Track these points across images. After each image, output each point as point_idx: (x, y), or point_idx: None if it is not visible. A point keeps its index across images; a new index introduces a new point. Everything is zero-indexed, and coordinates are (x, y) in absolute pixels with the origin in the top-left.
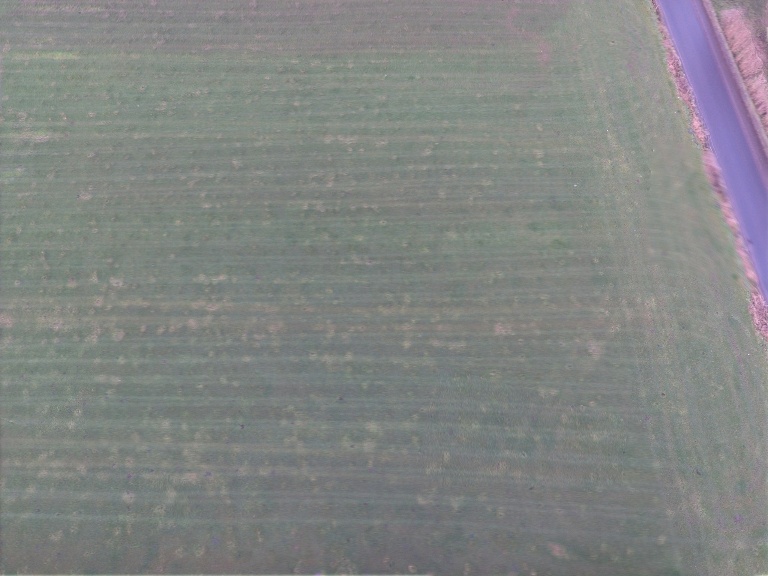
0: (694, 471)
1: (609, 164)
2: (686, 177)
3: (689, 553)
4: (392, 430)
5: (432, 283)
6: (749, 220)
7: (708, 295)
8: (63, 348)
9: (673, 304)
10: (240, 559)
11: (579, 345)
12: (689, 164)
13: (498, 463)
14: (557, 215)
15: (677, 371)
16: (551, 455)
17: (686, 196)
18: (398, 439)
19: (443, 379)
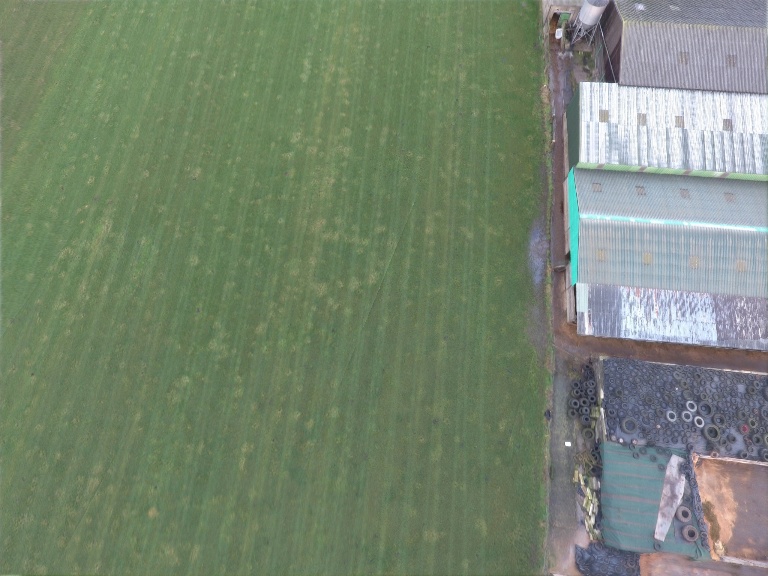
0: None
1: None
2: None
3: None
4: None
5: None
6: None
7: None
8: (352, 173)
9: None
10: (515, 45)
11: None
12: None
13: None
14: None
15: None
16: None
17: None
18: None
19: None
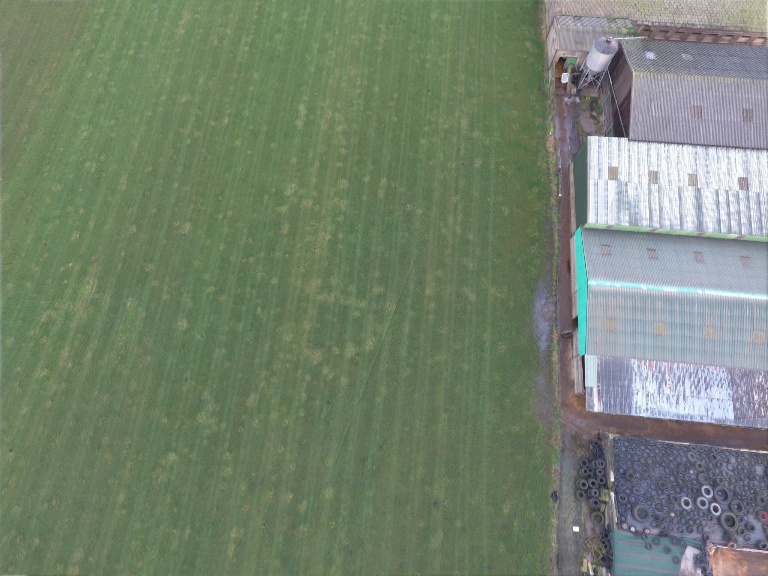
0: None
1: None
2: None
3: None
4: (437, 5)
5: None
6: None
7: None
8: (349, 229)
9: None
10: (519, 89)
11: None
12: None
13: None
14: None
15: None
16: None
17: None
18: (443, 2)
19: None
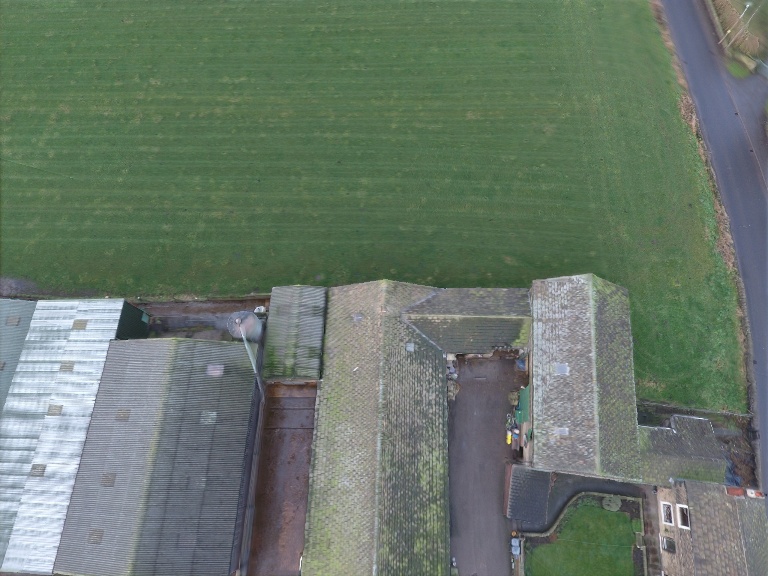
0: (622, 210)
1: (569, 1)
2: (633, 11)
3: (614, 263)
4: (380, 183)
5: (416, 83)
6: (685, 47)
7: (644, 94)
8: (112, 128)
9: (615, 99)
10: (257, 267)
11: (535, 126)
12: (636, 2)
13: (465, 204)
14: (523, 36)
15: (614, 144)
16: (508, 199)
17: (632, 25)
18: (385, 189)
19: (423, 149)
